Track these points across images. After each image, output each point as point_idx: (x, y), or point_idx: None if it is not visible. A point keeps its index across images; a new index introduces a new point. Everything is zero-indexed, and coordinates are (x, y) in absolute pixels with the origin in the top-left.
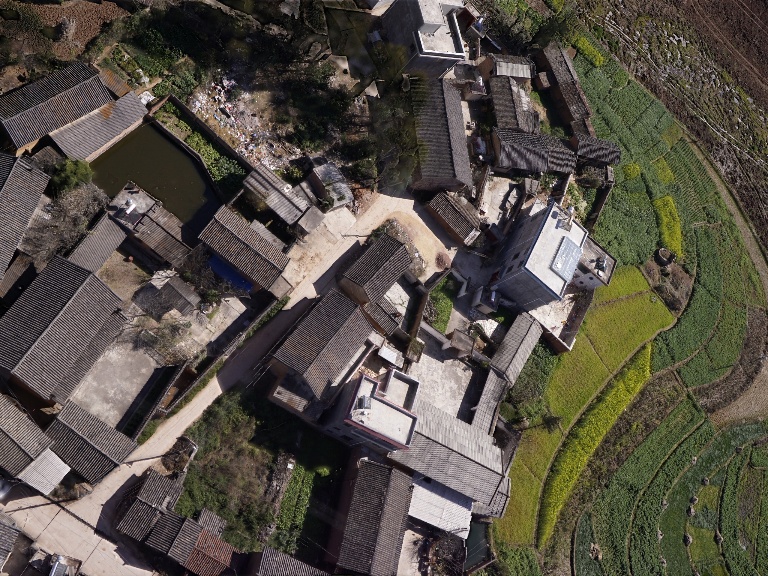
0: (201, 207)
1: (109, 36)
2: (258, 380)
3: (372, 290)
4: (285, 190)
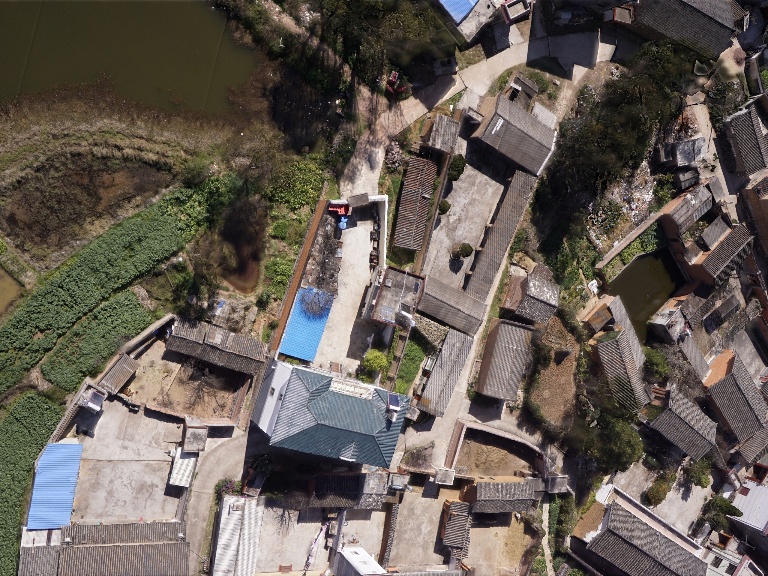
0: (664, 265)
1: (573, 315)
2: (767, 263)
3: (765, 157)
4: (693, 203)
